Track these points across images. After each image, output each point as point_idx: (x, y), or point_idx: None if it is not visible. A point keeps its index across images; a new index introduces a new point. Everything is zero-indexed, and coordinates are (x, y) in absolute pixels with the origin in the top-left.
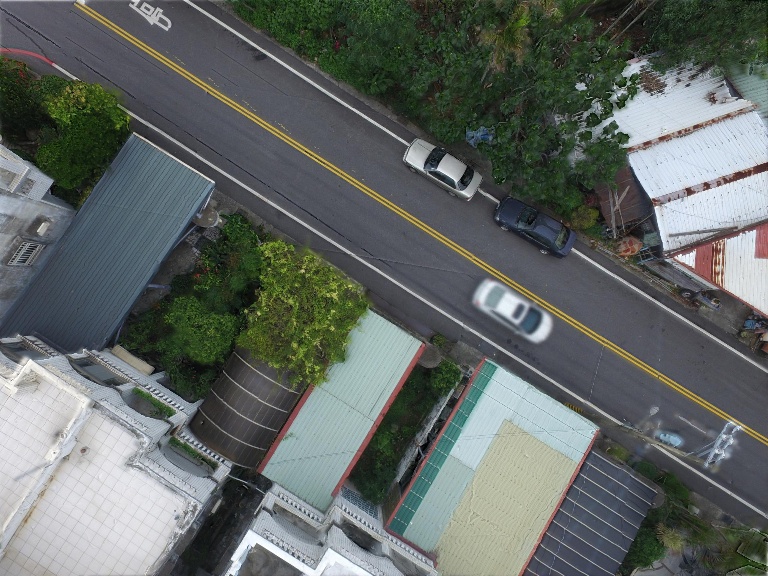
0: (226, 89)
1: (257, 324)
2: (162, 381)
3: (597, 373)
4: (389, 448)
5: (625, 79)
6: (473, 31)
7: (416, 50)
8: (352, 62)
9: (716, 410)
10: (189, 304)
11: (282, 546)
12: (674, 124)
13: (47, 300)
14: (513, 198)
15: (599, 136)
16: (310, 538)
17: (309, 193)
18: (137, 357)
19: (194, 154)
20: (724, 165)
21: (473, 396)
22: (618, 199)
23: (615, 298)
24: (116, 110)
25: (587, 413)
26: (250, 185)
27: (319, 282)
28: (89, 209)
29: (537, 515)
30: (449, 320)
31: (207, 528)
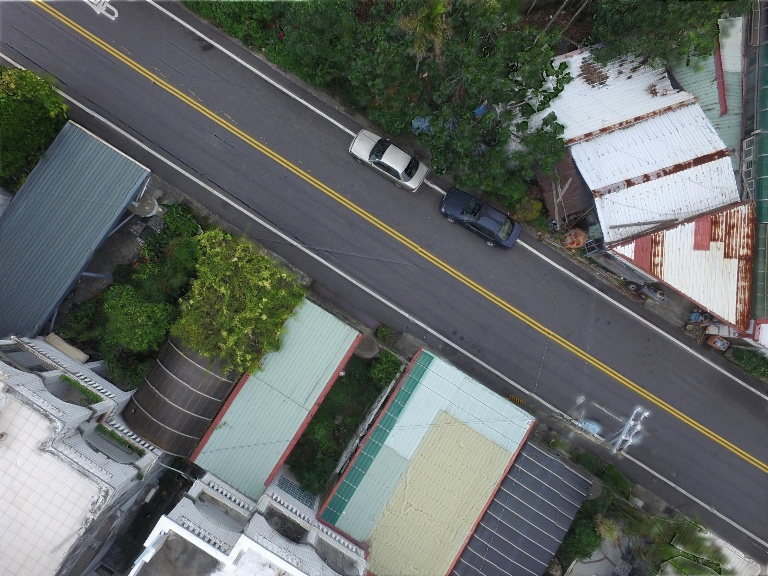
0: (172, 79)
1: (190, 312)
2: (99, 370)
3: (542, 365)
4: (332, 439)
5: None
6: None
7: (354, 39)
8: (296, 52)
9: (661, 403)
10: (124, 292)
11: (198, 532)
12: (615, 116)
13: None
14: (459, 190)
15: (539, 127)
16: (237, 526)
17: (255, 184)
18: (72, 345)
19: (140, 144)
20: (665, 157)
21: (409, 386)
22: (561, 191)
23: (561, 290)
24: (49, 97)
25: (526, 404)
26: (196, 175)
27: (252, 270)
28: (23, 196)
29: (472, 505)
30: (395, 311)
31: (142, 517)
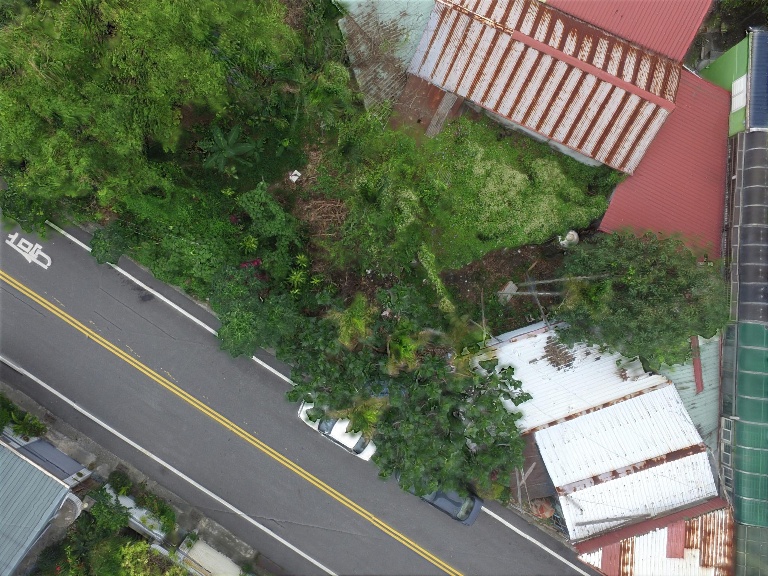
0: (109, 333)
1: None
2: None
3: None
4: None
5: (519, 382)
6: None
7: (295, 339)
8: None
9: None
10: None
11: None
12: (582, 402)
13: None
14: None
15: None
16: None
17: (196, 447)
18: None
19: (72, 404)
20: (635, 449)
21: None
22: (524, 474)
23: (527, 562)
24: None
25: None
26: (132, 438)
27: None
28: None
29: None
30: None
31: None
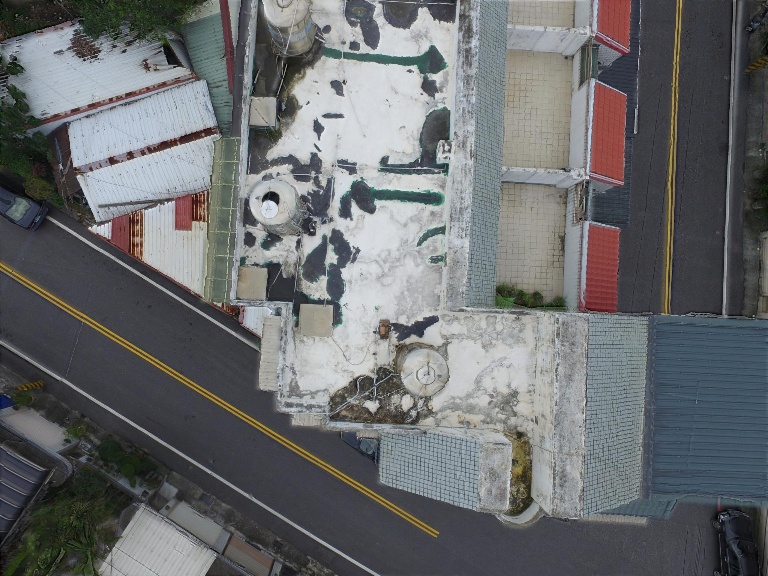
0: None
1: None
2: None
3: (75, 350)
4: None
5: None
6: None
7: None
8: None
9: (198, 388)
10: None
11: None
12: (105, 91)
13: None
14: None
15: None
16: None
17: None
18: None
19: None
20: (155, 134)
21: None
22: (63, 169)
23: (99, 273)
24: None
25: None
26: None
27: None
28: None
29: None
30: None
31: None
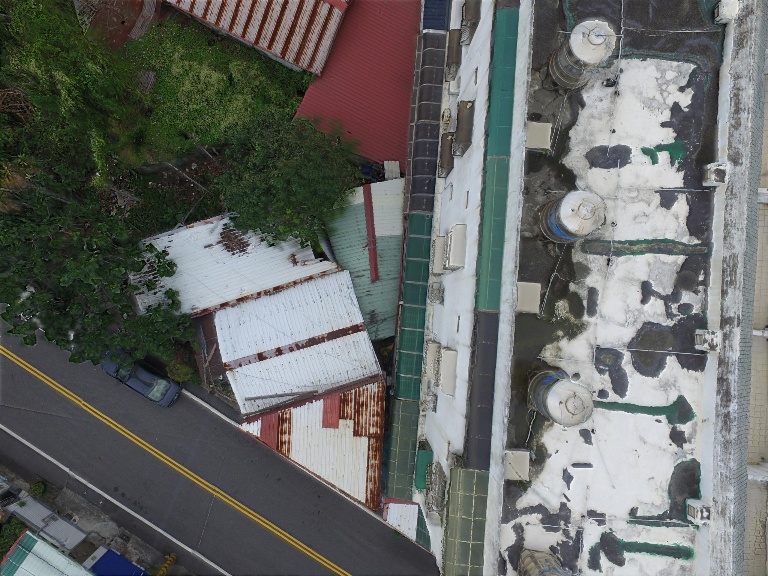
0: None
1: None
2: None
3: (207, 523)
4: None
5: (161, 254)
6: (112, 161)
7: None
8: None
9: (326, 562)
10: None
11: None
12: (254, 285)
13: None
14: None
15: None
16: None
17: None
18: None
19: None
20: (302, 329)
21: (10, 571)
22: (207, 355)
23: (230, 445)
24: None
25: None
26: None
27: None
28: None
29: None
30: (55, 466)
31: None
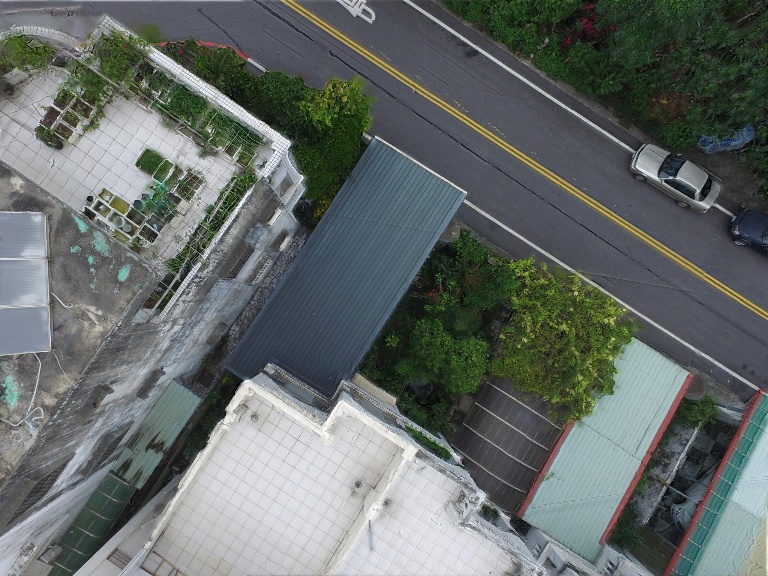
0: (435, 88)
1: (522, 352)
2: None
3: None
4: None
5: None
6: None
7: (689, 46)
8: (588, 59)
9: None
10: (435, 328)
11: None
12: None
13: (286, 323)
14: (752, 210)
15: None
16: None
17: (526, 203)
18: (377, 386)
19: None
20: None
21: (748, 432)
22: None
23: None
24: None
25: None
26: None
27: (594, 306)
28: (329, 221)
29: None
30: (678, 343)
31: None
